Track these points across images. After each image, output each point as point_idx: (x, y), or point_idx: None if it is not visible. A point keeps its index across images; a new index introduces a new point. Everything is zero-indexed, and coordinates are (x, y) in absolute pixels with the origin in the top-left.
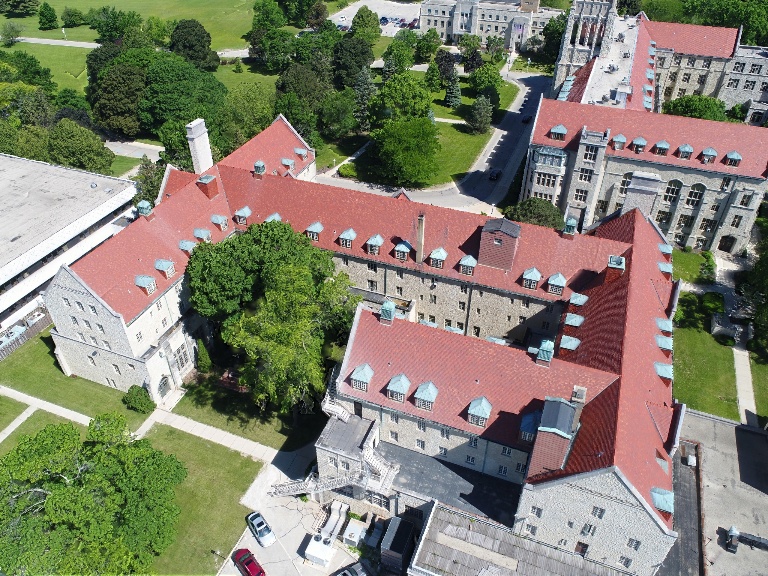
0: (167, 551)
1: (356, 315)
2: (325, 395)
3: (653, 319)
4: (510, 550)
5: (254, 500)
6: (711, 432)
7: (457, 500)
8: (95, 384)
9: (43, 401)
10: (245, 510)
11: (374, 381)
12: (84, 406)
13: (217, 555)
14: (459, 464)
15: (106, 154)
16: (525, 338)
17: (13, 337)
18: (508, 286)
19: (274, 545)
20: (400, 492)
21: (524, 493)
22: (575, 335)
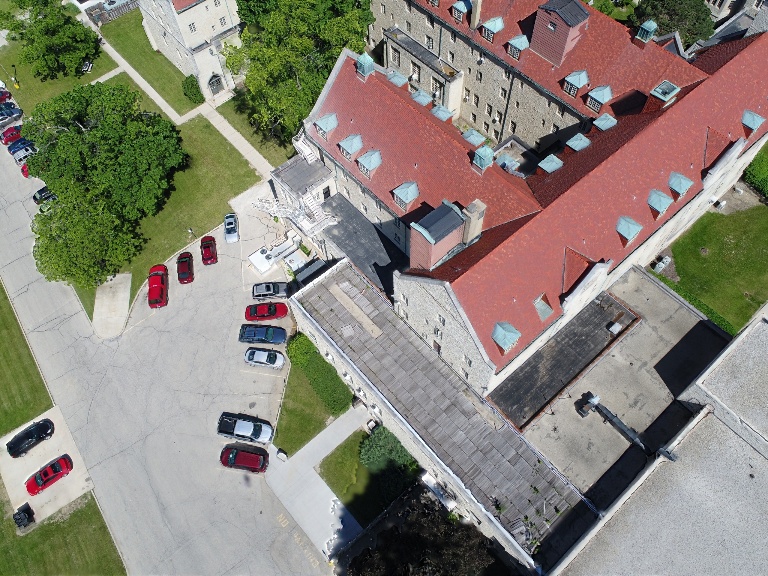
0: (161, 216)
1: (338, 60)
2: (298, 132)
3: (667, 172)
4: (382, 322)
5: (239, 205)
6: (667, 314)
7: (368, 266)
8: (171, 64)
9: (130, 66)
10: (229, 209)
11: (335, 133)
12: (155, 80)
13: (192, 233)
14: (390, 239)
15: None
16: (546, 149)
17: (124, 0)
18: (549, 84)
19: (235, 244)
20: (325, 240)
21: (394, 278)
22: (566, 159)
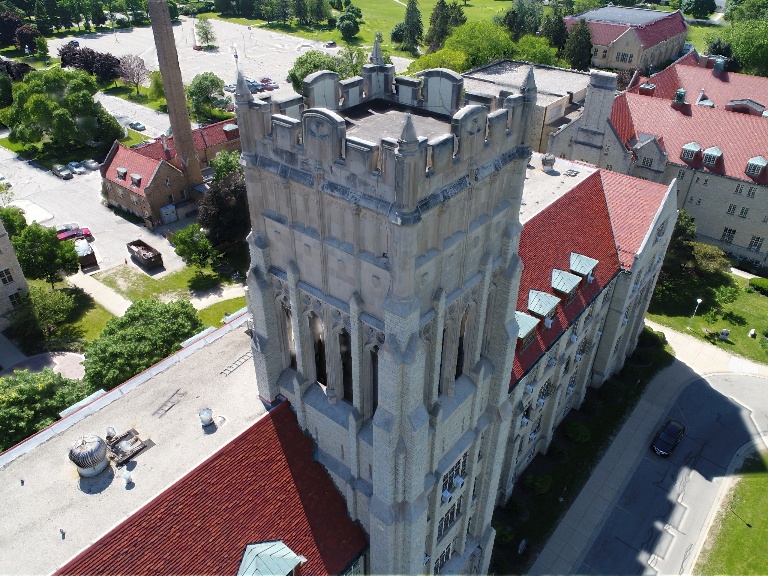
0: None
1: None
2: None
3: None
4: None
5: None
6: None
7: None
8: None
9: None
10: None
11: None
12: None
13: None
14: None
15: None
16: None
17: None
18: None
19: None
20: None
21: None
22: None
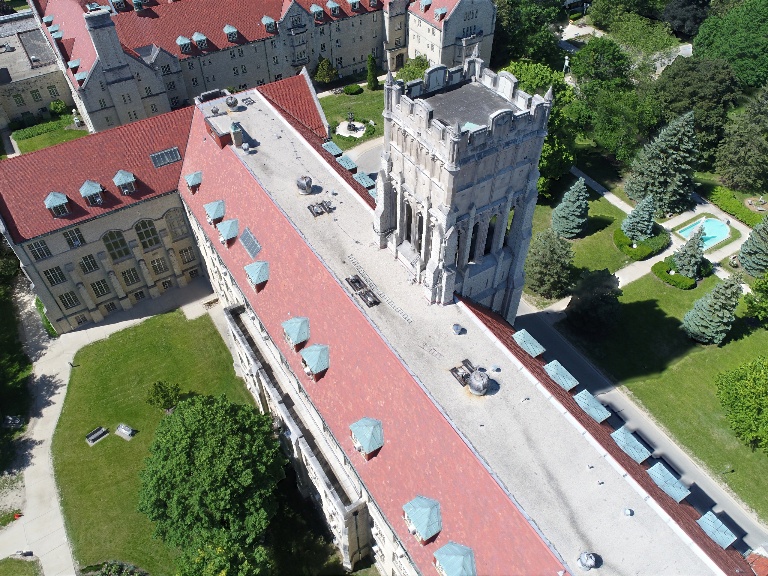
0: None
1: None
2: None
3: None
4: None
5: None
6: (27, 76)
7: None
8: None
9: None
10: None
11: None
12: None
13: None
14: None
15: (616, 8)
16: None
17: None
18: None
19: None
20: None
21: None
22: None
